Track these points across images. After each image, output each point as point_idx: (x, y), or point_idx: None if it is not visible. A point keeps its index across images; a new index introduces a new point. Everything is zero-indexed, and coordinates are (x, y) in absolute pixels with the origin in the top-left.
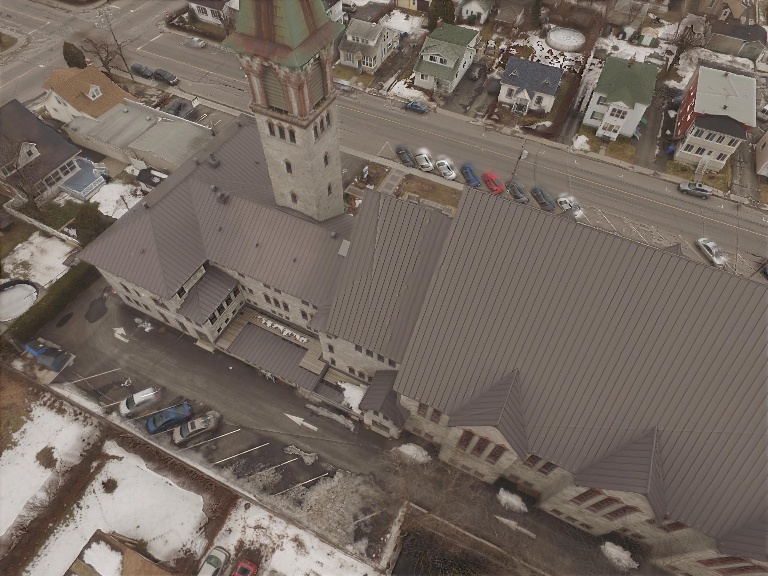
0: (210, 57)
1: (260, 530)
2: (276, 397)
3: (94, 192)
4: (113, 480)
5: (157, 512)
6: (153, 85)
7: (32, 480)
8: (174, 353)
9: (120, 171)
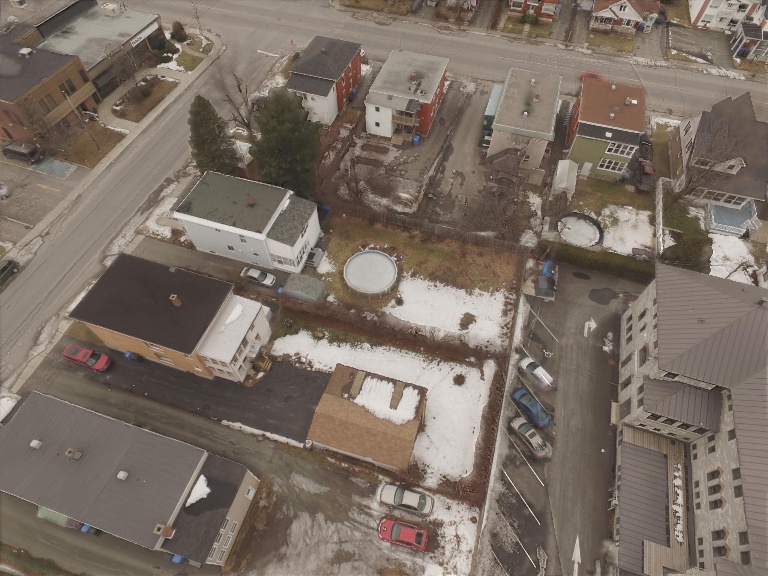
0: None
1: (456, 542)
2: (592, 517)
3: (722, 233)
4: (464, 380)
5: (449, 430)
6: None
7: (449, 319)
8: (593, 384)
9: (763, 241)
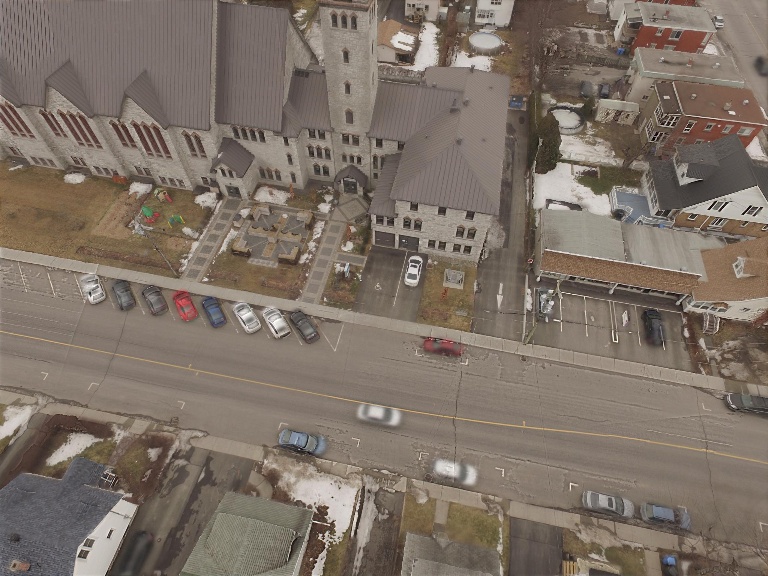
0: (756, 506)
1: None
2: None
3: None
4: None
5: None
6: (754, 387)
7: None
8: None
9: None
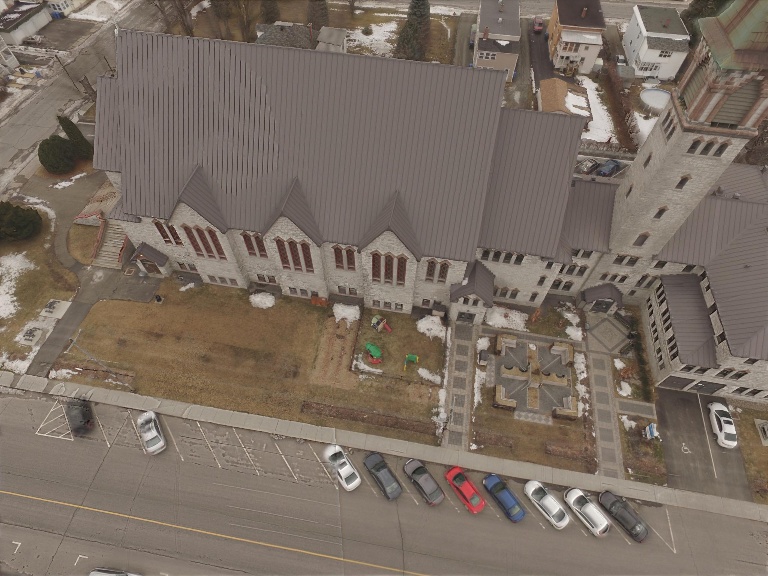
0: None
1: None
2: None
3: None
4: None
5: None
6: None
7: None
8: None
9: None
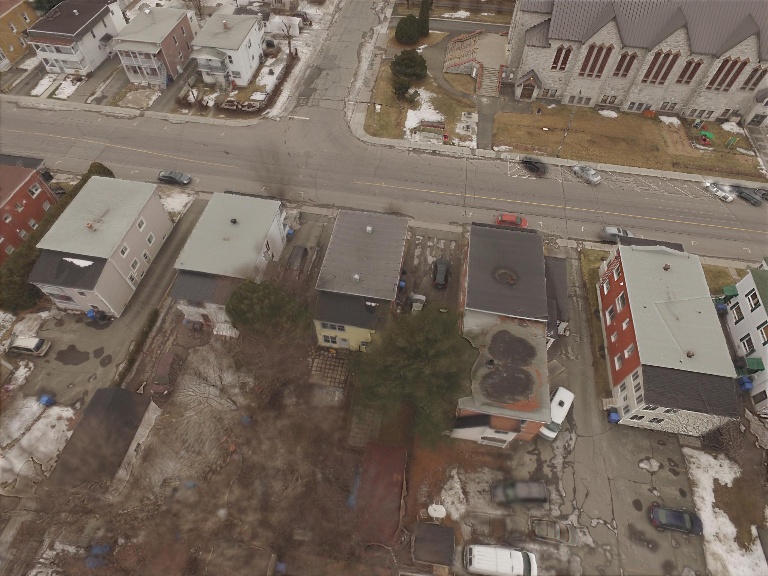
0: None
1: None
2: None
3: None
4: None
5: None
6: None
7: None
8: None
9: None
